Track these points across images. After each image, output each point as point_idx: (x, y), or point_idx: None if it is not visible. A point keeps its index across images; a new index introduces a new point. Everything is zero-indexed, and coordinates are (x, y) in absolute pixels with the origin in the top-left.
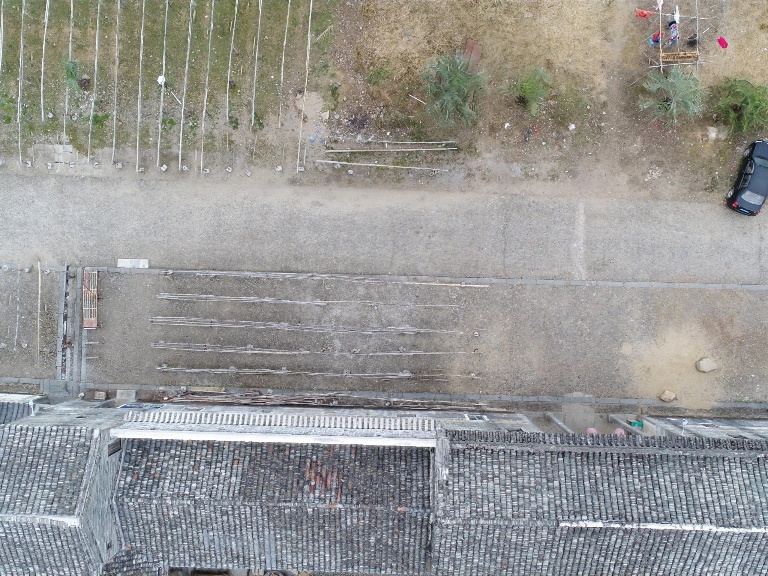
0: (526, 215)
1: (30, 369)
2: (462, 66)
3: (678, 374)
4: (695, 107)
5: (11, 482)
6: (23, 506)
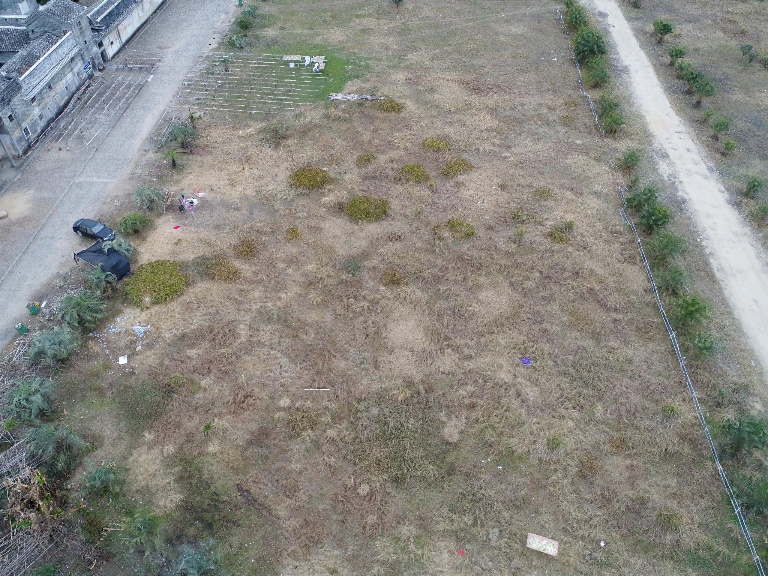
0: (118, 165)
1: (122, 60)
2: (191, 137)
3: (5, 207)
4: (139, 200)
5: (63, 7)
6: (53, 6)
